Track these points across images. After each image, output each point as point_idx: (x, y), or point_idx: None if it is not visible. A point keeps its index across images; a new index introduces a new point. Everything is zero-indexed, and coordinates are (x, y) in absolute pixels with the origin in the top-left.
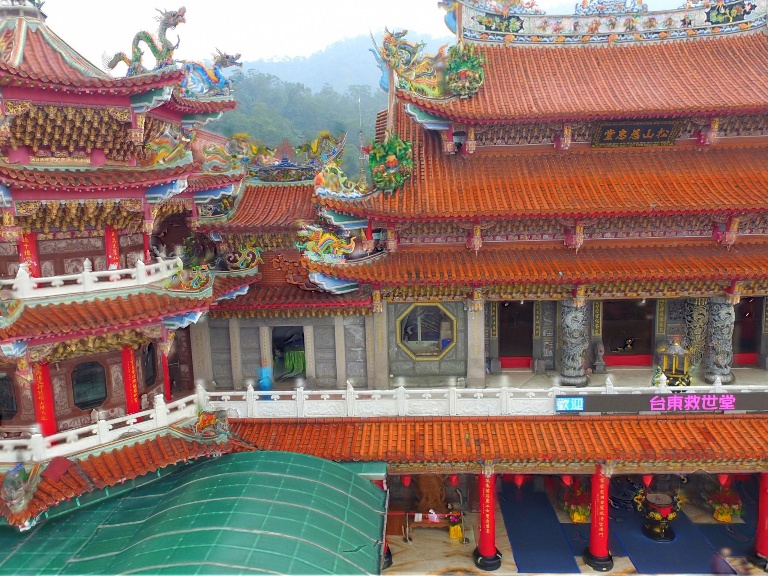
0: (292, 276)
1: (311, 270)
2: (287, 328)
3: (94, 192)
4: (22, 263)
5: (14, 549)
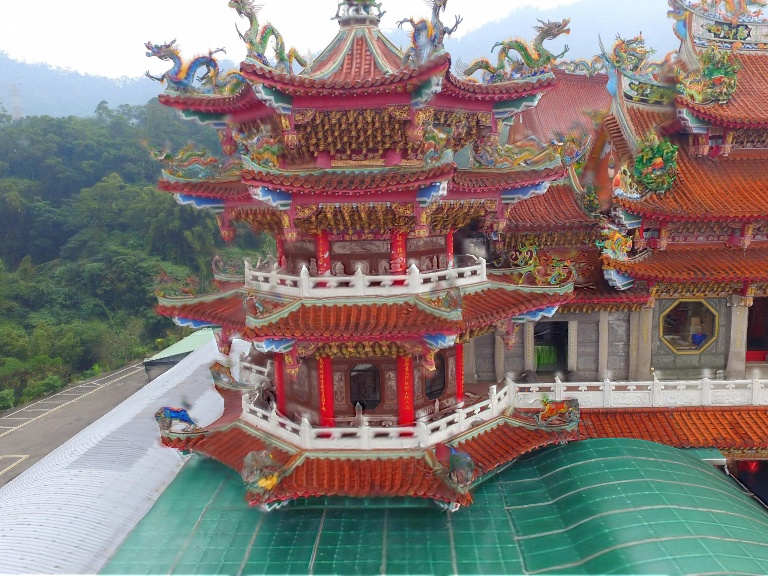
0: None
1: (607, 267)
2: (550, 323)
3: (480, 193)
4: (394, 260)
5: (448, 528)
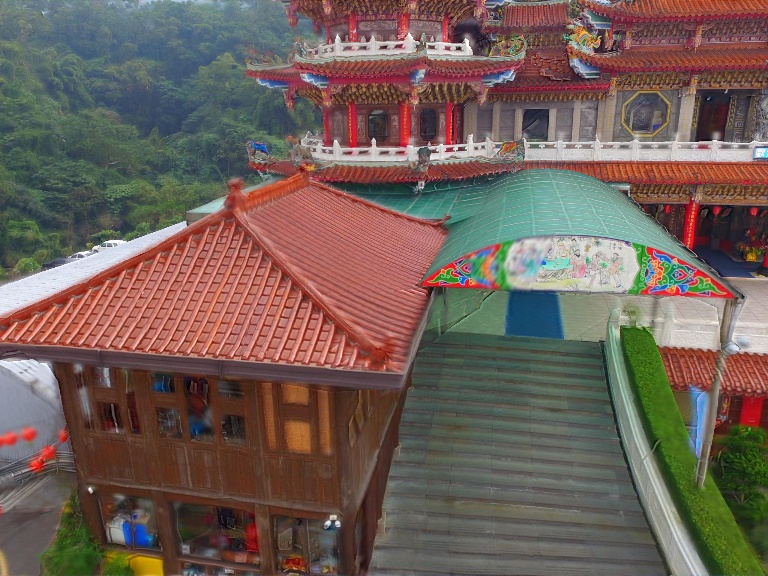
0: (545, 70)
1: (572, 56)
2: (536, 111)
3: None
4: (400, 35)
5: (416, 198)
